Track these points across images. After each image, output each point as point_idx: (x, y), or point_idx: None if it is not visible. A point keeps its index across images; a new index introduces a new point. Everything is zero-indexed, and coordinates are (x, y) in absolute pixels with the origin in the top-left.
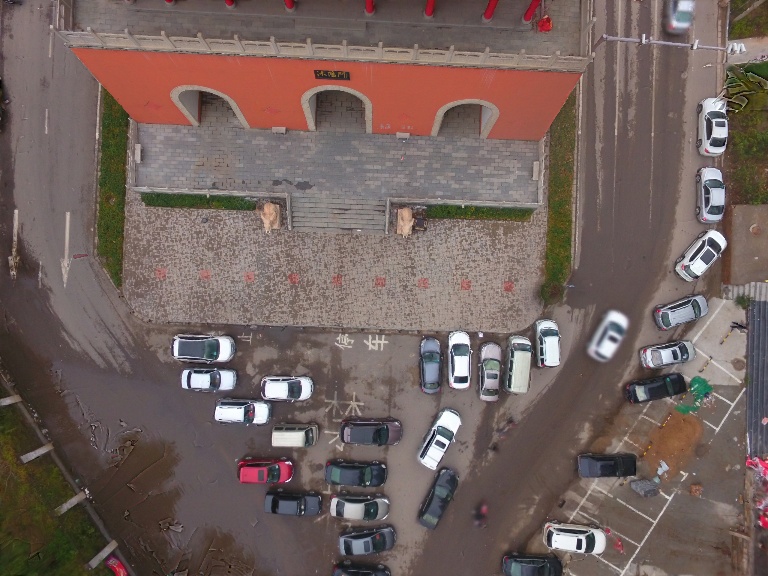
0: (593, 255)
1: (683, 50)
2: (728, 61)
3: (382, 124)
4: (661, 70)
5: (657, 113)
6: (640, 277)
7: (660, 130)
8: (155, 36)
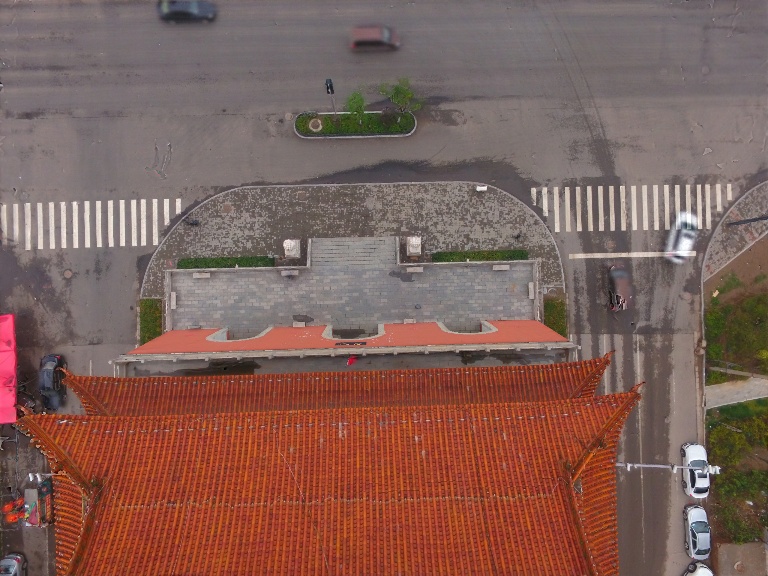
0: None
1: (665, 397)
2: (706, 405)
3: None
4: (646, 417)
5: (645, 457)
6: None
7: (648, 472)
8: None
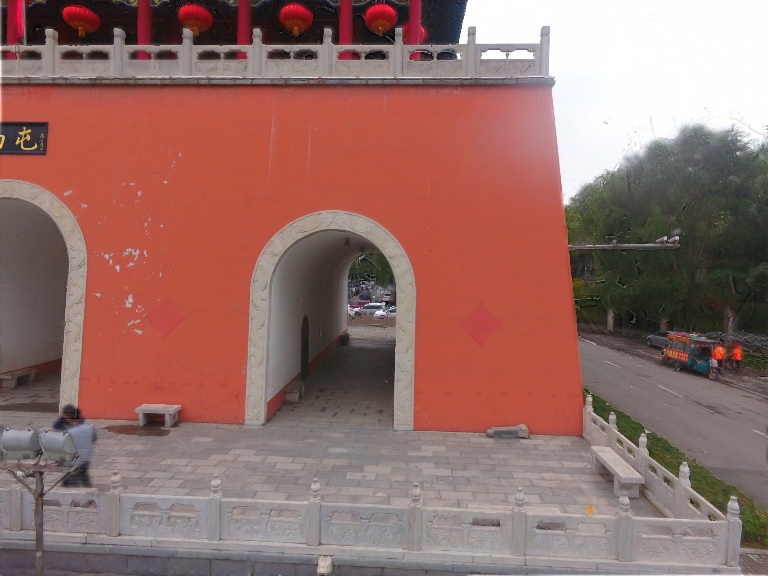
0: None
1: None
2: None
3: None
4: None
5: None
6: None
7: None
8: None
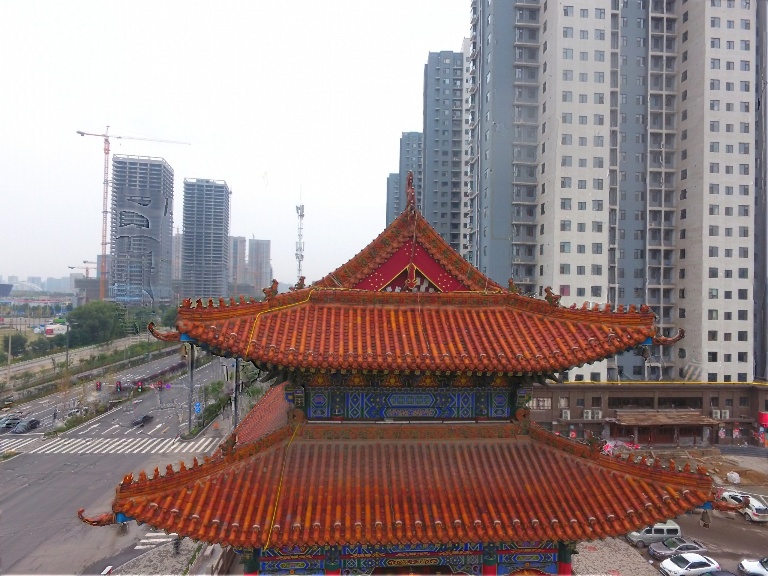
0: None
1: None
2: None
3: None
4: None
5: None
6: None
7: None
8: None
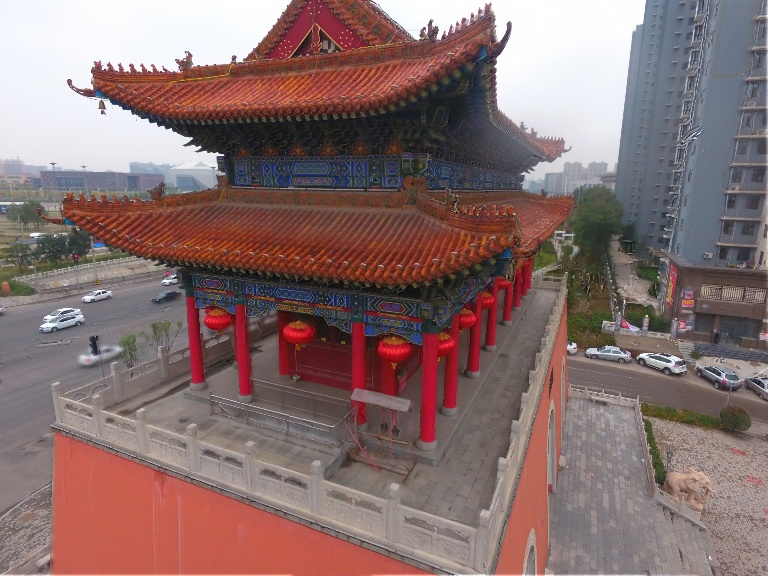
0: (676, 404)
1: None
2: None
3: (556, 458)
4: None
5: None
6: (690, 390)
7: None
8: (521, 415)
